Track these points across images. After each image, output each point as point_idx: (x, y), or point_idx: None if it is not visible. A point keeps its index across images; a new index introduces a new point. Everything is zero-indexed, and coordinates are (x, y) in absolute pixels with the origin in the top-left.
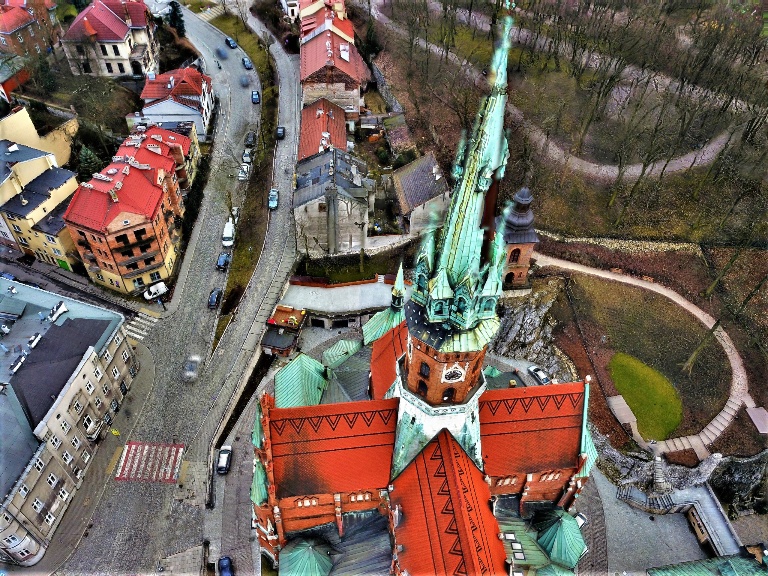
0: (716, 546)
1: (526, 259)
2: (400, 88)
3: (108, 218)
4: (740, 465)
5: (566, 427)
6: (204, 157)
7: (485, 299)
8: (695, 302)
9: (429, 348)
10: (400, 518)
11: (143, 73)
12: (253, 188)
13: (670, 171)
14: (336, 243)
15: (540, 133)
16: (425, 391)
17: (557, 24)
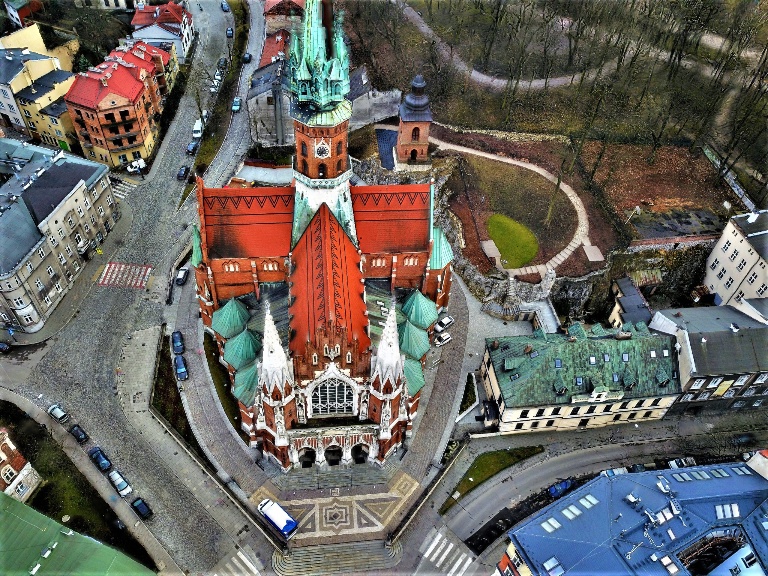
0: None
1: (425, 138)
2: (350, 25)
3: (99, 98)
4: (572, 284)
5: (419, 219)
6: None
7: (333, 84)
8: None
9: (304, 127)
10: (293, 268)
11: (135, 8)
12: (221, 98)
13: (556, 85)
14: (283, 134)
15: (457, 57)
16: (308, 170)
17: None
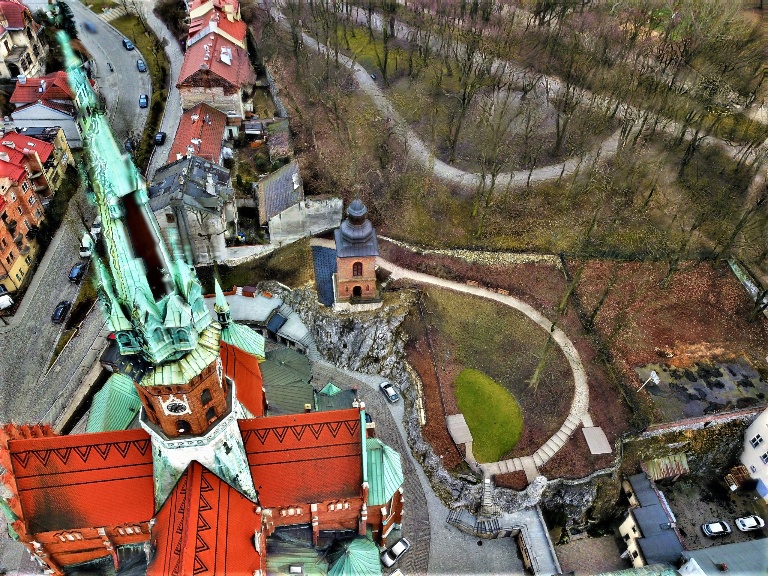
0: (535, 573)
1: (370, 272)
2: None
3: None
4: (570, 488)
5: (345, 455)
6: (78, 163)
7: (173, 330)
8: (548, 316)
9: None
10: (152, 555)
11: None
12: None
13: (542, 180)
14: (193, 254)
15: (417, 140)
16: None
17: (461, 27)
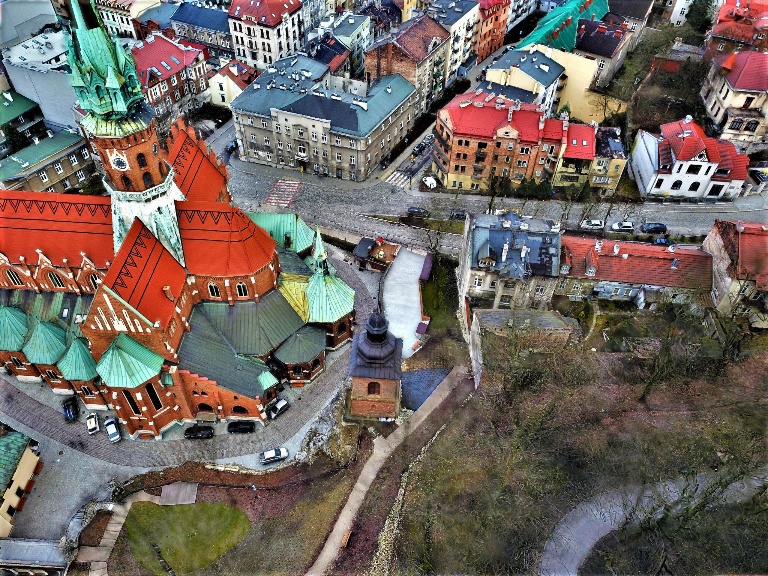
0: None
1: None
2: None
3: None
4: None
5: None
6: None
7: None
8: None
9: None
10: None
11: (722, 129)
12: None
13: None
14: None
15: None
16: None
17: None
